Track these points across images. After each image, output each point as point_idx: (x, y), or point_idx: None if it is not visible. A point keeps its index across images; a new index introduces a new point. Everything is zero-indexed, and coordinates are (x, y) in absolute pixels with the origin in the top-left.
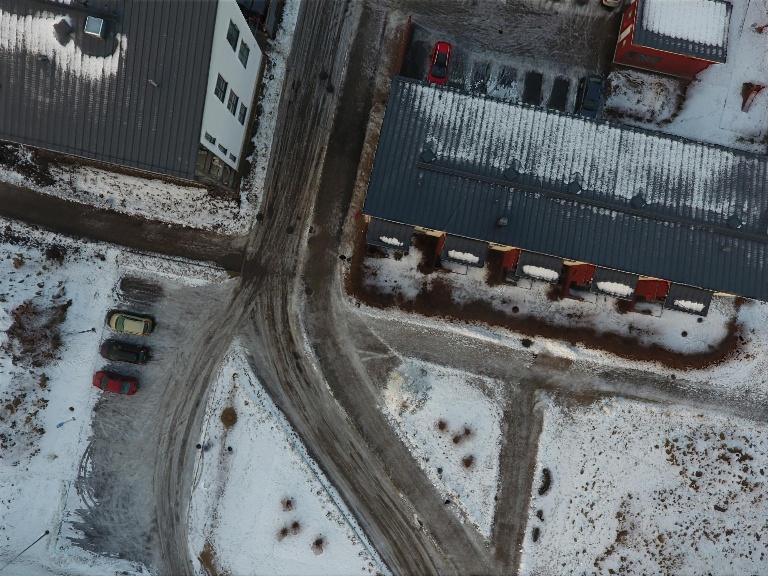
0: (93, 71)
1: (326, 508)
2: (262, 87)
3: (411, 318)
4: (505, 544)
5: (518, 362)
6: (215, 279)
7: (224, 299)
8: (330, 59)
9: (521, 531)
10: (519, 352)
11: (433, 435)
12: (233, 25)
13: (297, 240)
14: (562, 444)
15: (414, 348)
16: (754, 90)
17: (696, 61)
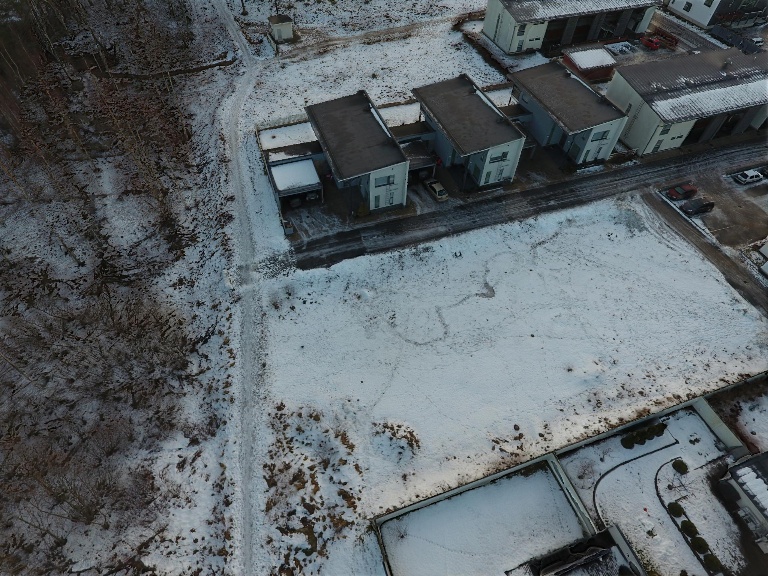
0: None
1: None
2: None
3: None
4: None
5: None
6: None
7: None
8: None
9: None
10: None
11: None
12: None
13: None
14: None
15: None
16: None
17: None
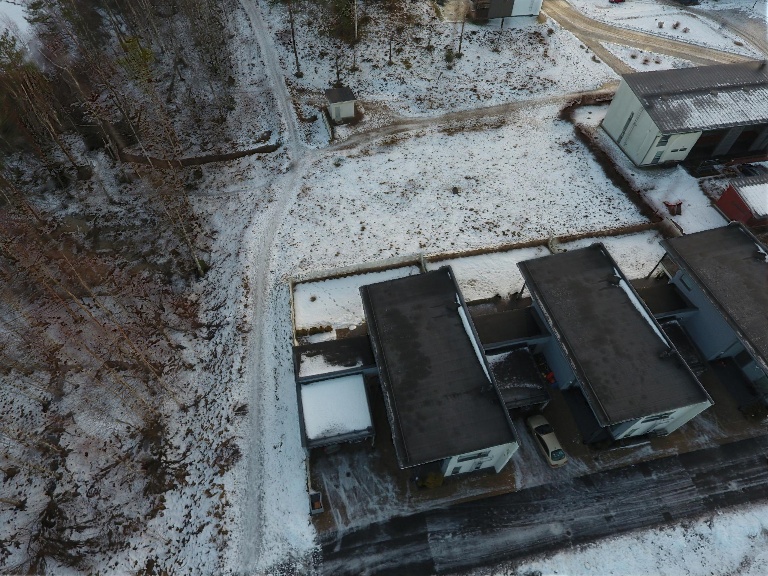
0: None
1: (670, 34)
2: None
3: None
4: None
5: None
6: None
7: None
8: None
9: None
10: None
11: (657, 59)
12: None
13: None
14: None
15: None
16: (678, 205)
17: None
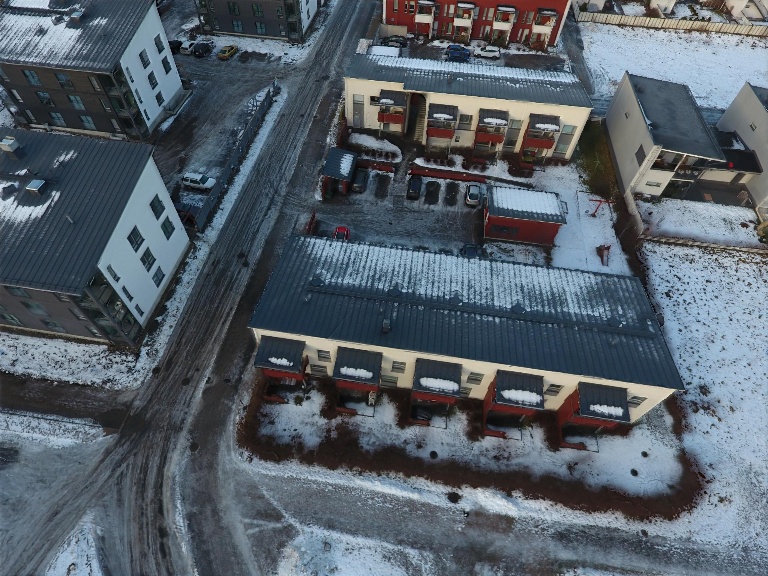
0: (21, 216)
1: None
2: (185, 264)
3: (312, 472)
4: None
5: (446, 524)
6: (86, 438)
7: (90, 461)
8: (249, 245)
9: None
10: (446, 510)
11: None
12: (160, 202)
13: (191, 392)
14: None
15: (315, 512)
16: (605, 249)
17: (544, 225)
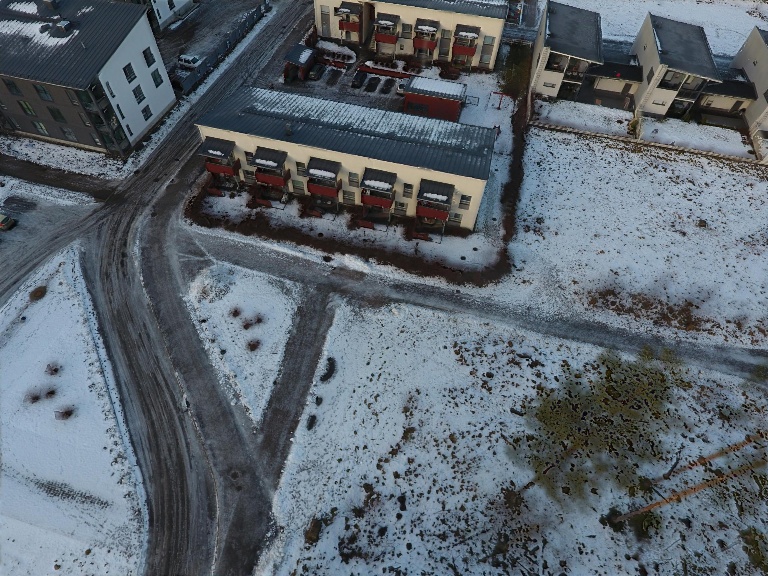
0: (52, 43)
1: (92, 379)
2: (170, 113)
3: (232, 236)
4: (275, 431)
5: (318, 271)
6: (82, 202)
7: (83, 215)
8: None
9: (296, 418)
10: (320, 265)
11: (225, 321)
12: (151, 55)
13: (159, 186)
14: (350, 337)
15: (228, 255)
16: (496, 128)
17: (446, 102)
